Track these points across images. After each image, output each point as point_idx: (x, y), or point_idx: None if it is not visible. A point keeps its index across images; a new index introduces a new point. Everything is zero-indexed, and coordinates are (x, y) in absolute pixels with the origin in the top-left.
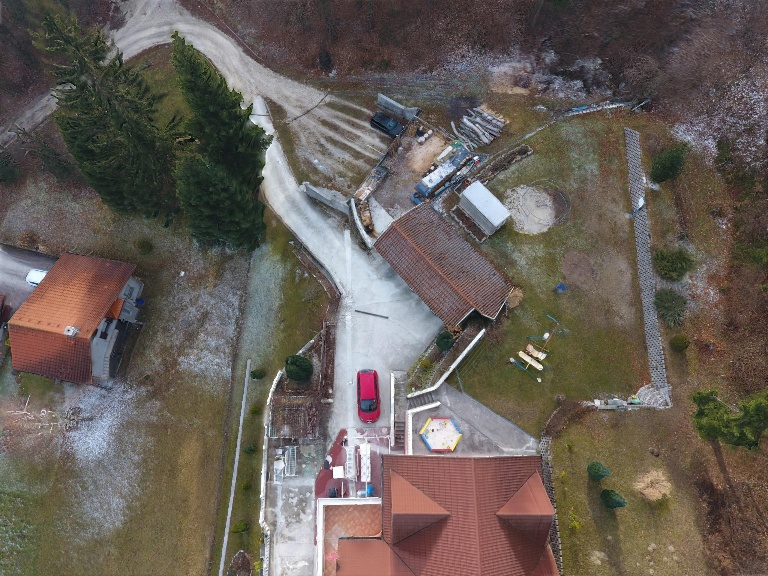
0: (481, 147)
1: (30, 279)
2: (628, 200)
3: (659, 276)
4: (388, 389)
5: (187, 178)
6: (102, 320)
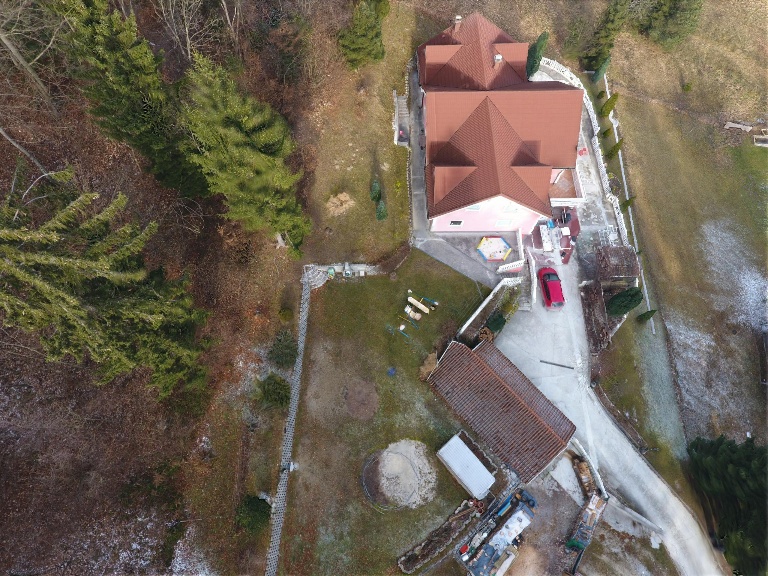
0: None
1: None
2: (291, 488)
3: None
4: None
5: None
6: None
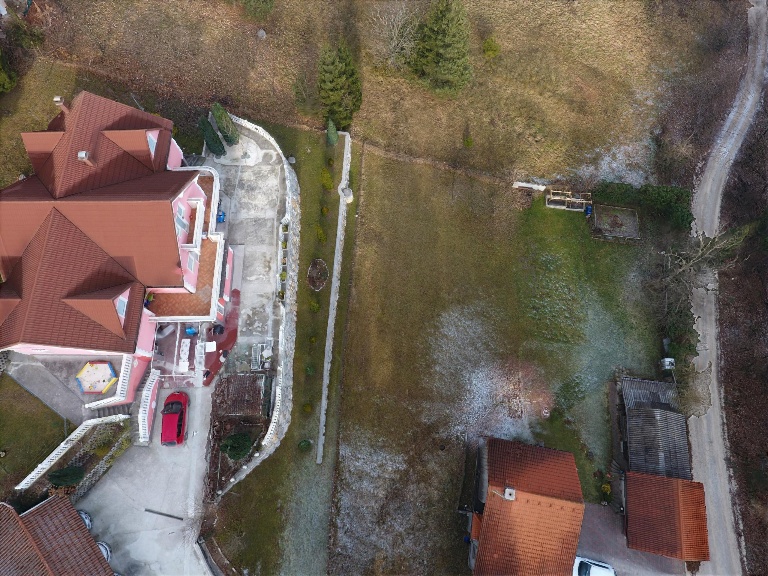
0: None
1: (609, 573)
2: None
3: None
4: (157, 427)
5: None
6: None
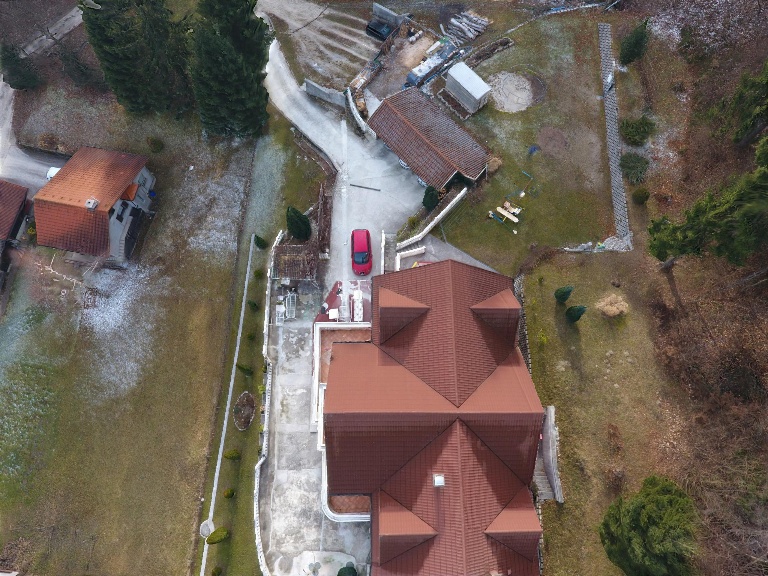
0: (467, 43)
1: (51, 175)
2: (600, 84)
3: (625, 143)
4: (379, 249)
5: (199, 48)
6: (118, 201)
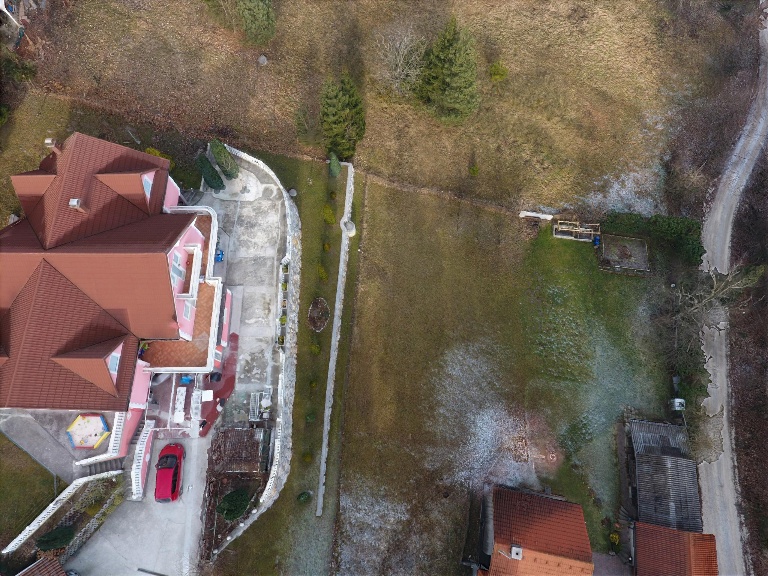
0: None
1: None
2: None
3: None
4: (151, 480)
5: None
6: None
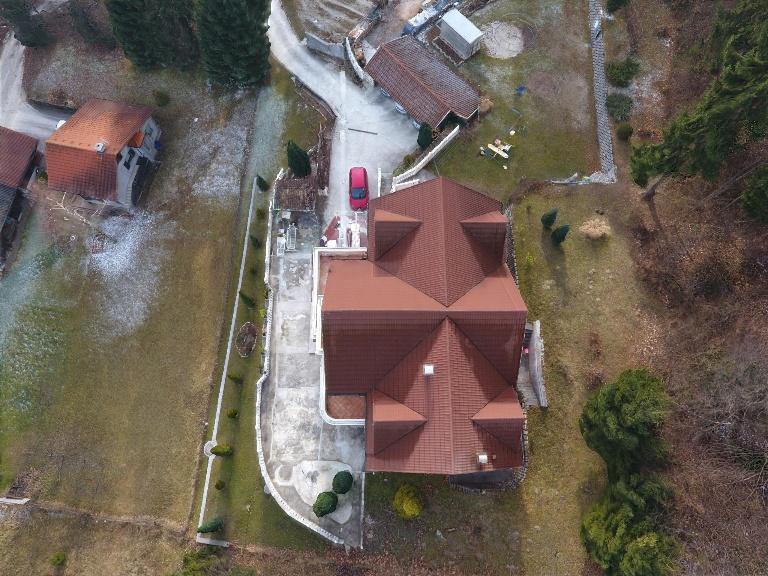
0: None
1: None
2: (588, 33)
3: (610, 84)
4: (376, 187)
5: None
6: (126, 148)
